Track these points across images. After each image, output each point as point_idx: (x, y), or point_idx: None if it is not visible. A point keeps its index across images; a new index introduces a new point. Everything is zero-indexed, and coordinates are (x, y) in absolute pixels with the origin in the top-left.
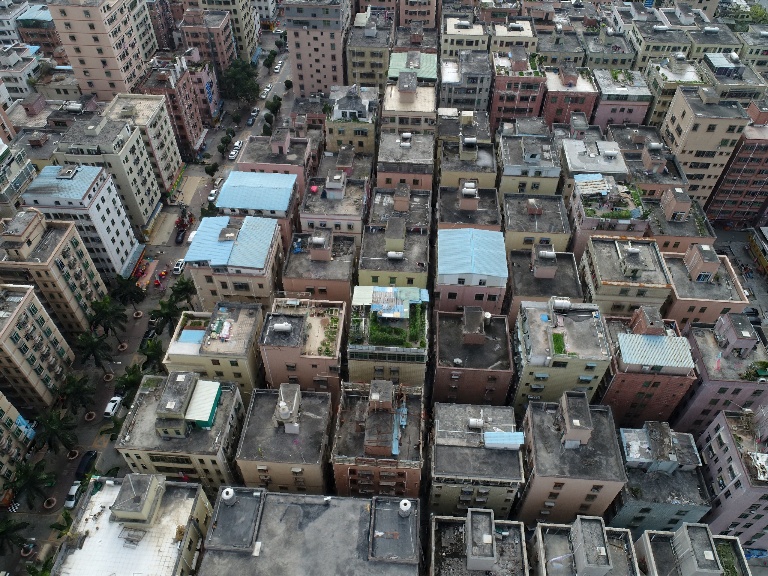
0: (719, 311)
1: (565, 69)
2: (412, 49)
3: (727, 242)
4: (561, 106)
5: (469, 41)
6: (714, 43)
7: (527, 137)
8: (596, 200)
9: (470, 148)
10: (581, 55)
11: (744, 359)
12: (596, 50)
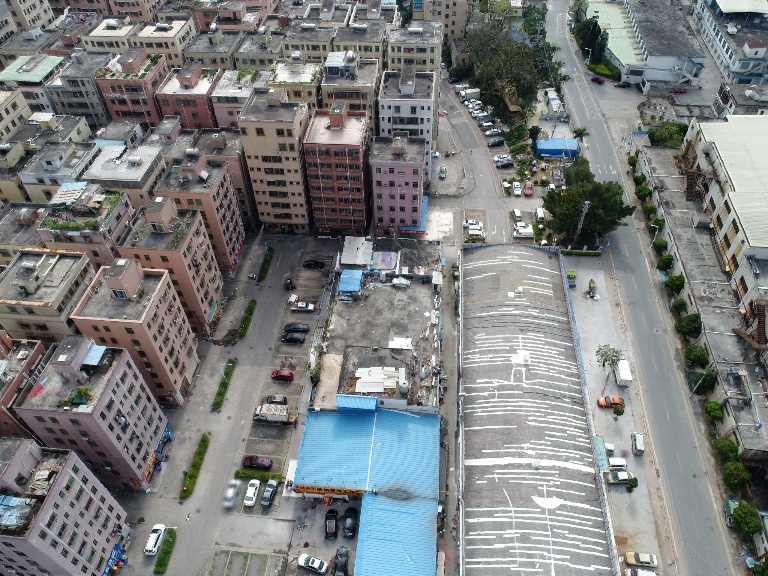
0: (124, 330)
1: (185, 70)
2: (58, 52)
3: (333, 252)
4: (177, 109)
5: (109, 43)
6: (352, 41)
7: (64, 143)
8: (67, 210)
9: (1, 155)
10: (225, 55)
11: (82, 385)
12: (246, 50)
